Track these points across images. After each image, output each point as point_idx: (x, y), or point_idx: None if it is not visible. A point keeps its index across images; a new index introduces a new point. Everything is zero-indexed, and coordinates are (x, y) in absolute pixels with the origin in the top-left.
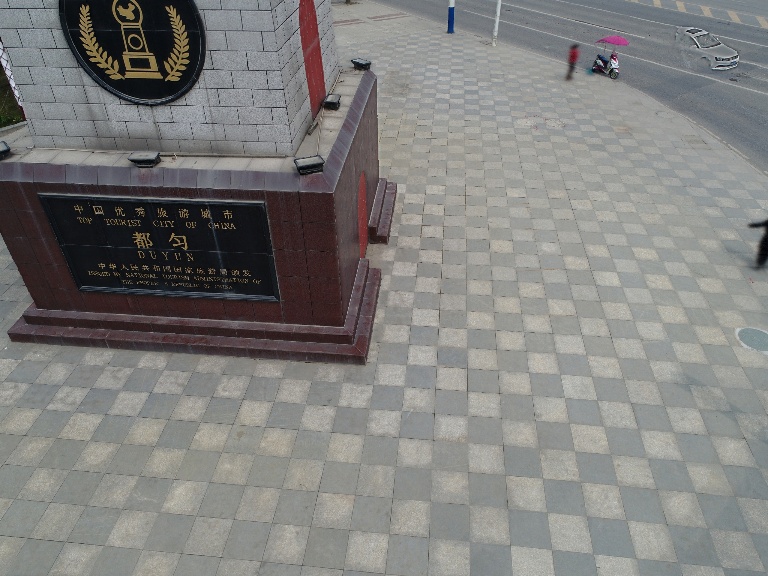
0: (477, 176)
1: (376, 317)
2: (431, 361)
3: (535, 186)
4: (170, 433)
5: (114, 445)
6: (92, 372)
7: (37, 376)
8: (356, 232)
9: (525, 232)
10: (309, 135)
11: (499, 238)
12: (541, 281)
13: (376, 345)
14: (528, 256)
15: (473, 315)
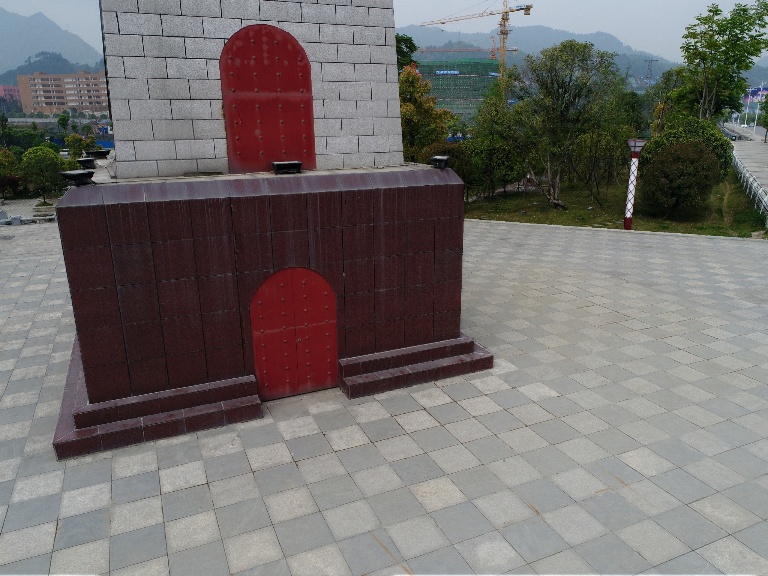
0: (635, 411)
1: (170, 439)
2: (71, 510)
3: (705, 476)
4: None
5: None
6: (45, 341)
7: (39, 328)
8: (228, 326)
9: (516, 507)
10: (184, 176)
11: (462, 483)
12: (358, 573)
13: (105, 456)
14: (434, 532)
15: (204, 518)
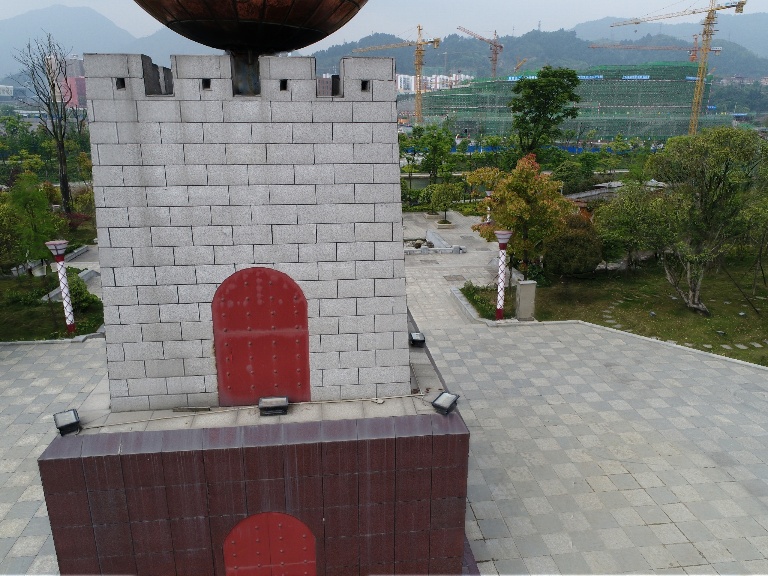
0: None
1: None
2: None
3: None
4: (0, 543)
5: (3, 516)
6: None
7: None
8: (200, 562)
9: None
10: (173, 411)
11: None
12: None
13: None
14: None
15: None
